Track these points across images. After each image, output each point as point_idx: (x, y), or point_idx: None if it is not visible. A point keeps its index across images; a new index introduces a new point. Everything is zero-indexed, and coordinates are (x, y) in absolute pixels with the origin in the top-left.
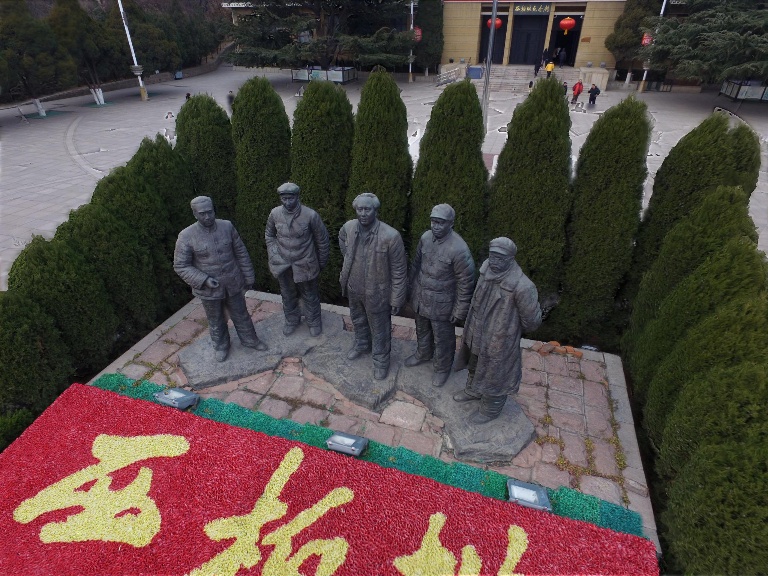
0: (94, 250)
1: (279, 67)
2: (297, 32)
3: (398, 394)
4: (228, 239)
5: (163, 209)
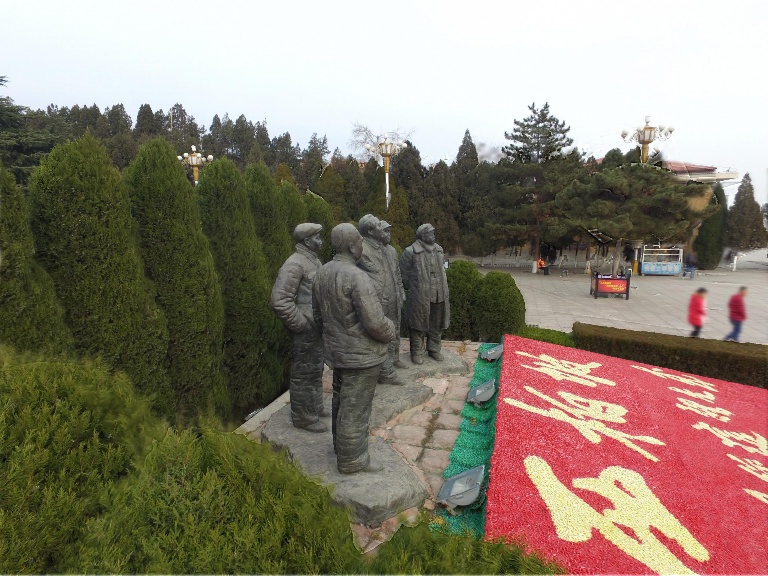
0: None
1: None
2: None
3: None
4: None
5: None
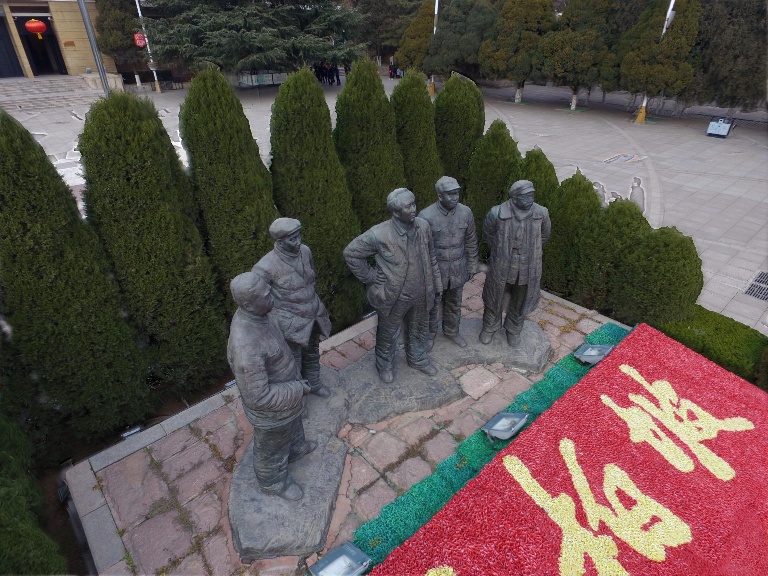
0: None
1: None
2: None
3: (454, 373)
4: None
5: None
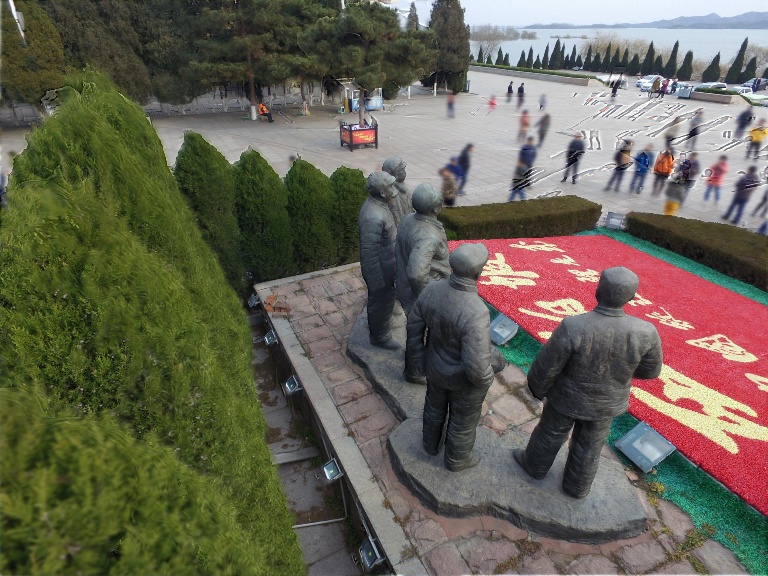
0: None
1: None
2: None
3: None
4: None
5: None
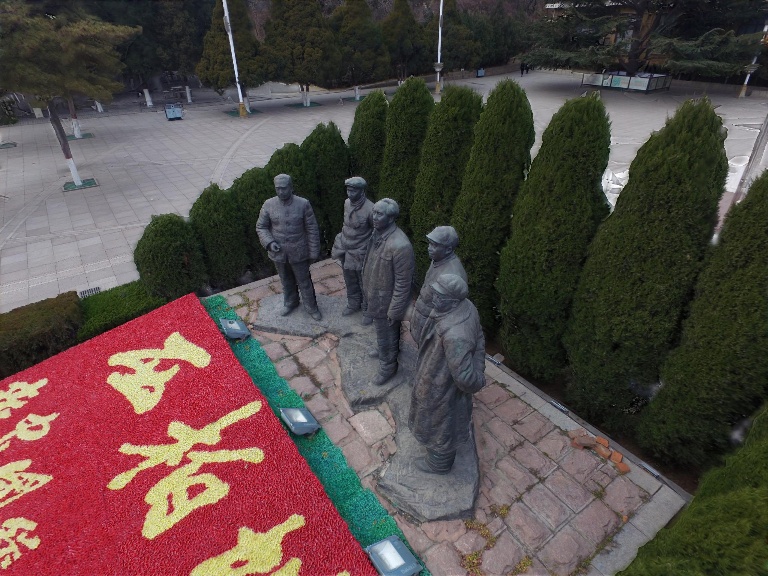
0: (245, 203)
1: (571, 70)
2: (603, 34)
3: (382, 405)
4: (299, 215)
5: (311, 183)
